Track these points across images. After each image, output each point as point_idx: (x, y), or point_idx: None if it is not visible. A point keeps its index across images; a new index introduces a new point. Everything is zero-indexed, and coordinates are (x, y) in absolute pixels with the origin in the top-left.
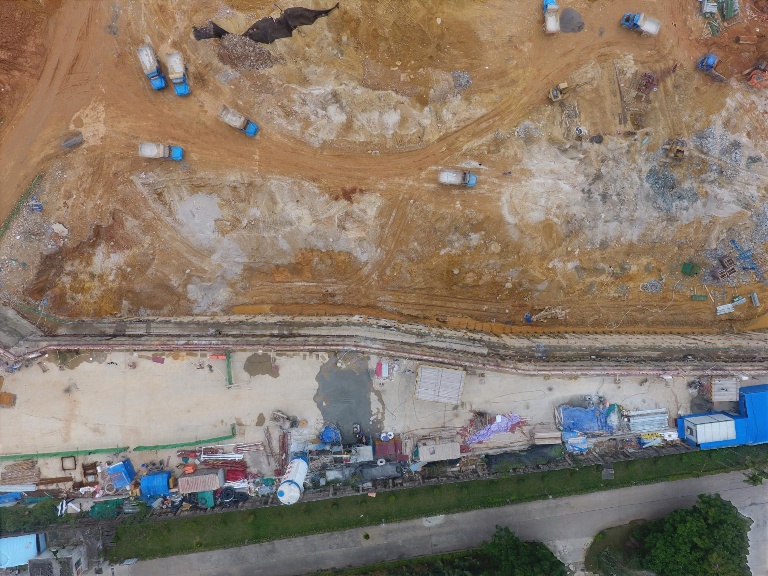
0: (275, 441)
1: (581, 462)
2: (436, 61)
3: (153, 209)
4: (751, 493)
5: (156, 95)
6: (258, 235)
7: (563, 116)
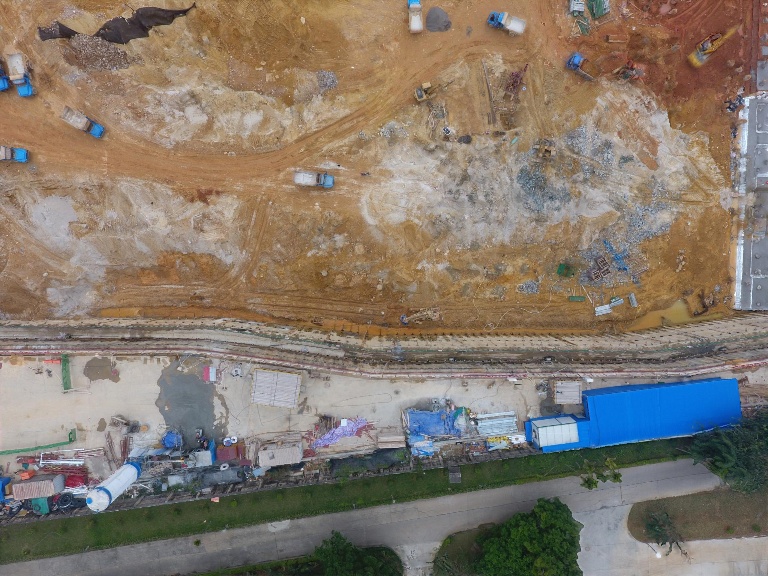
0: (117, 446)
1: (422, 466)
2: (301, 61)
3: (4, 212)
4: (601, 496)
5: (2, 96)
6: (114, 238)
7: (430, 116)
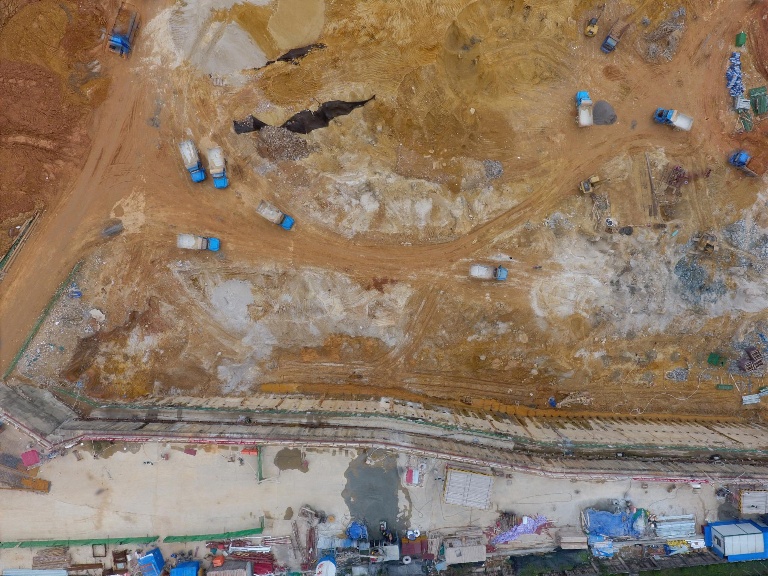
0: (302, 535)
1: (607, 570)
2: (469, 150)
3: (188, 295)
4: None
5: (195, 186)
6: (289, 321)
7: (594, 207)
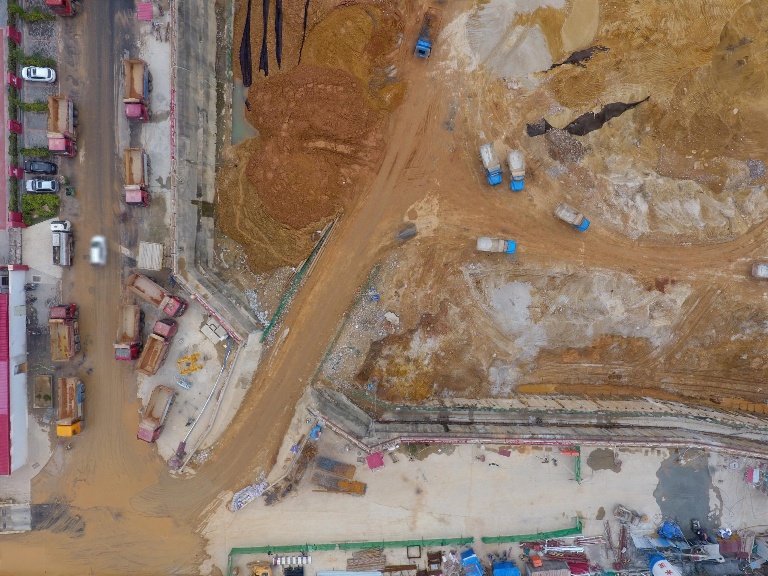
0: (614, 535)
1: None
2: (730, 150)
3: (472, 297)
4: None
5: (487, 189)
6: (569, 323)
7: None
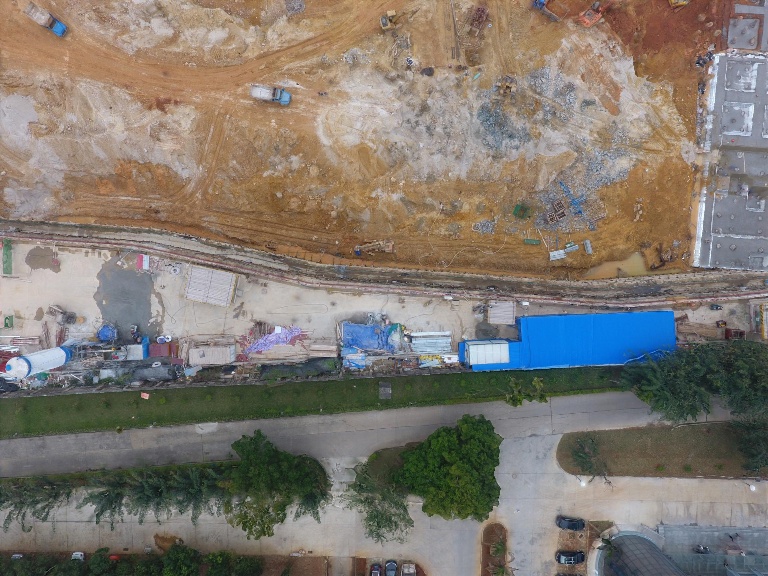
0: (53, 336)
1: (351, 375)
2: None
3: None
4: (532, 424)
5: None
6: (72, 140)
7: (394, 46)
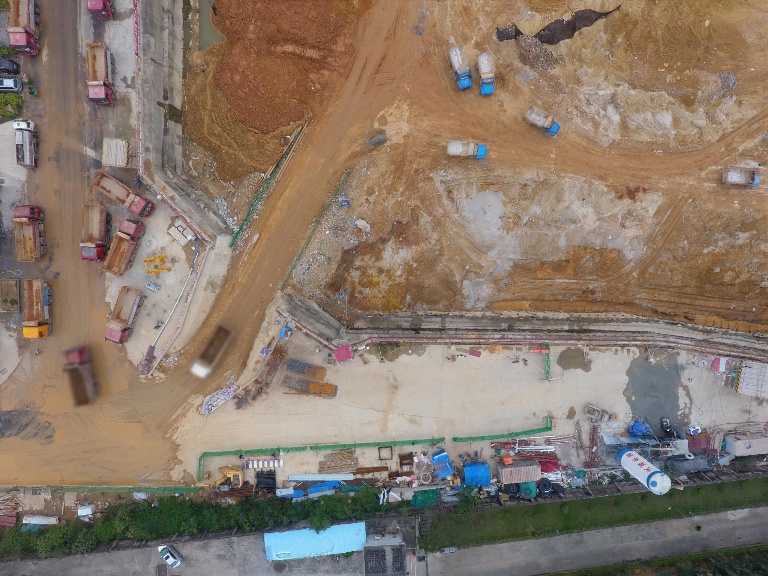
0: (585, 434)
1: None
2: (702, 63)
3: (444, 206)
4: None
5: (457, 94)
6: (541, 232)
7: None
